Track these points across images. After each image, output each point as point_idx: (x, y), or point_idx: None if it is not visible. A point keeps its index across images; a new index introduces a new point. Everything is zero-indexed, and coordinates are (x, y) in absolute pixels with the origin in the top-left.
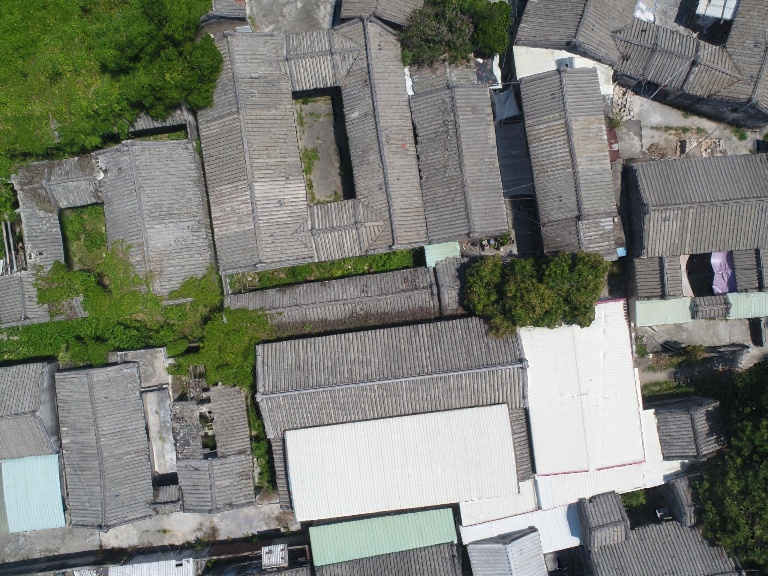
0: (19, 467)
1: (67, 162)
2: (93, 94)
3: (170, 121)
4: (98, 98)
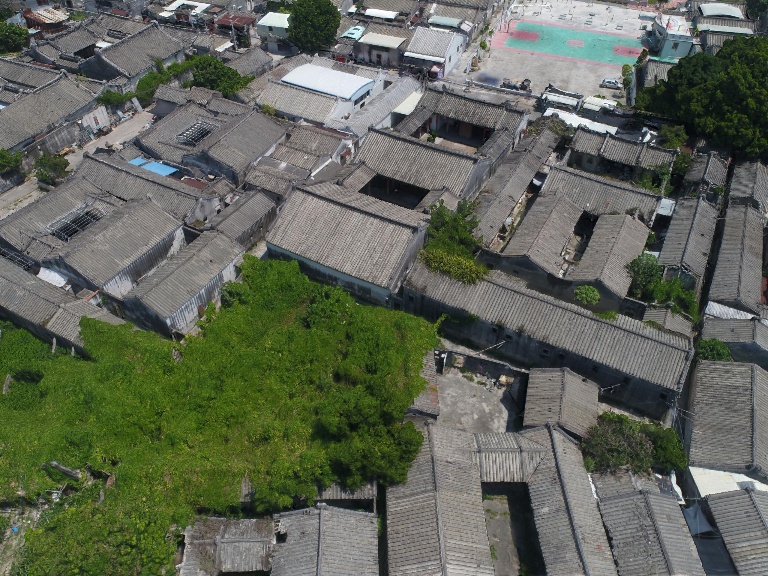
0: None
1: (244, 522)
2: (298, 457)
3: (358, 494)
4: (305, 460)
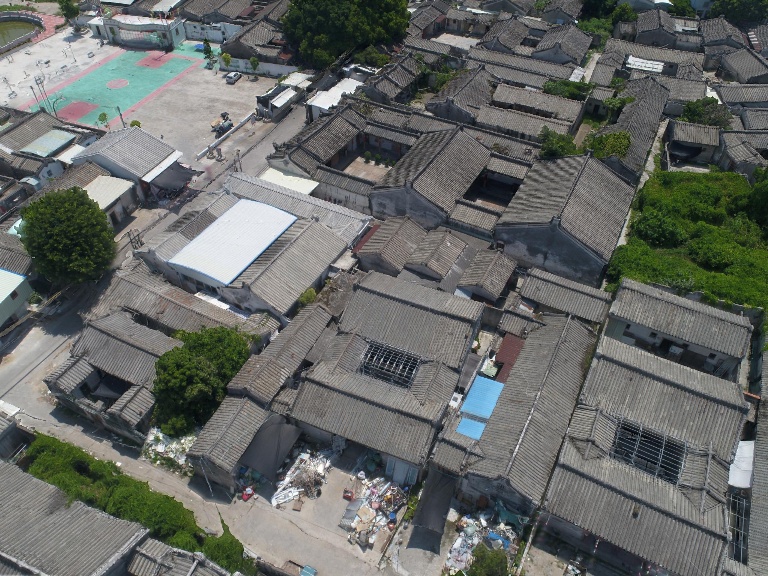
0: None
1: None
2: None
3: None
4: None
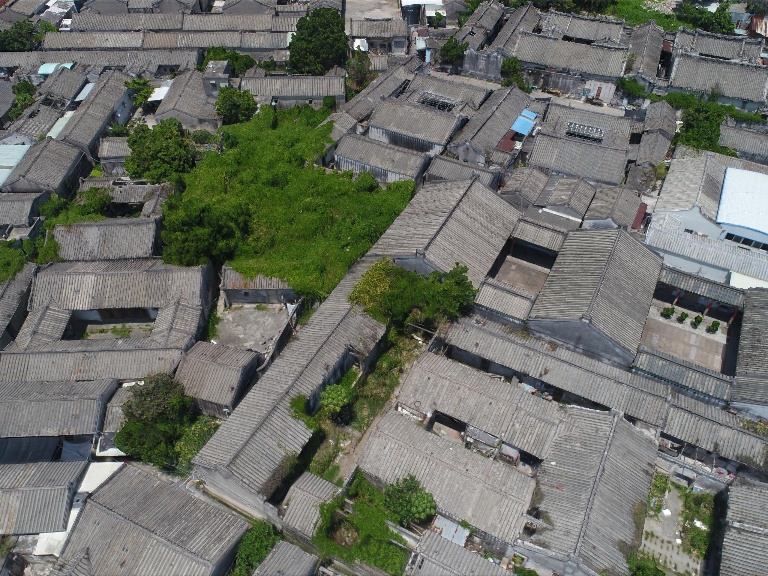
0: (3, 175)
1: None
2: None
3: None
4: None
